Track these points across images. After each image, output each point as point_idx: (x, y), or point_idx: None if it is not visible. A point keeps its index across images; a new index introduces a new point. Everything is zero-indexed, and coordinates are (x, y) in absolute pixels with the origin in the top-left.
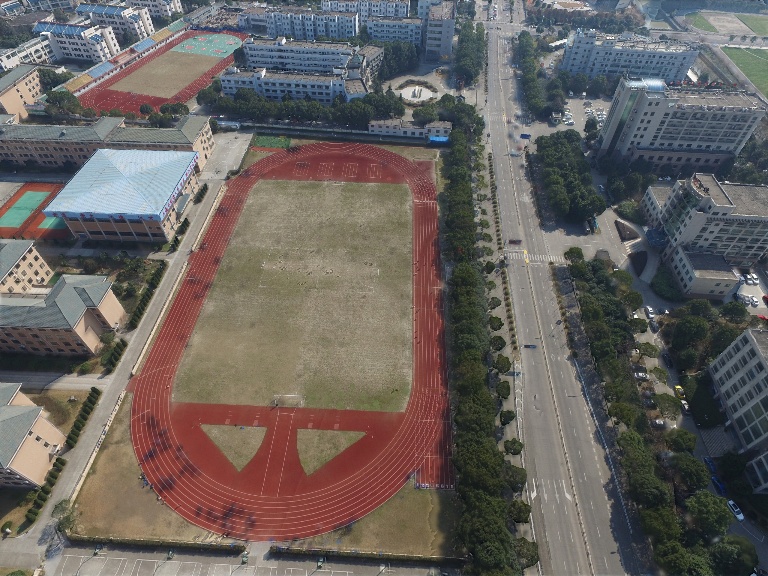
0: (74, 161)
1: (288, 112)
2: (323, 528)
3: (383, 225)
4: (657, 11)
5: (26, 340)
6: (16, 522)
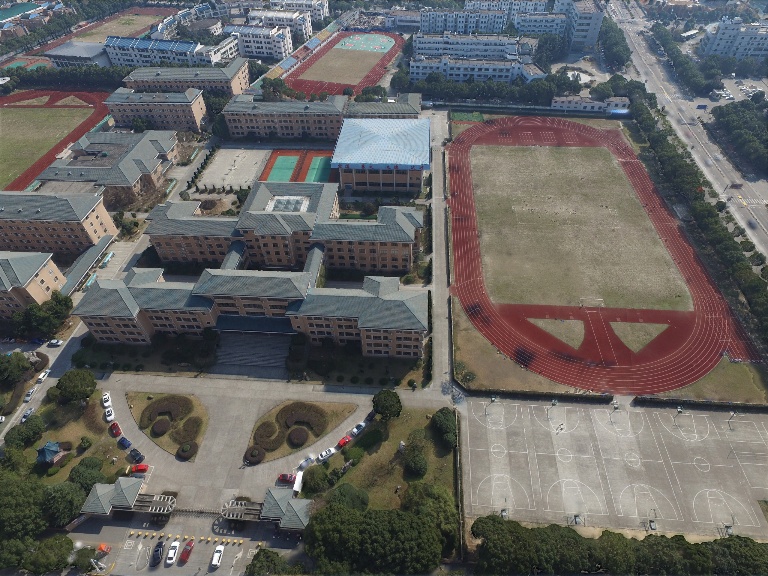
0: (309, 132)
1: (479, 91)
2: (669, 387)
3: (601, 178)
4: (762, 7)
5: (361, 256)
6: (417, 380)
